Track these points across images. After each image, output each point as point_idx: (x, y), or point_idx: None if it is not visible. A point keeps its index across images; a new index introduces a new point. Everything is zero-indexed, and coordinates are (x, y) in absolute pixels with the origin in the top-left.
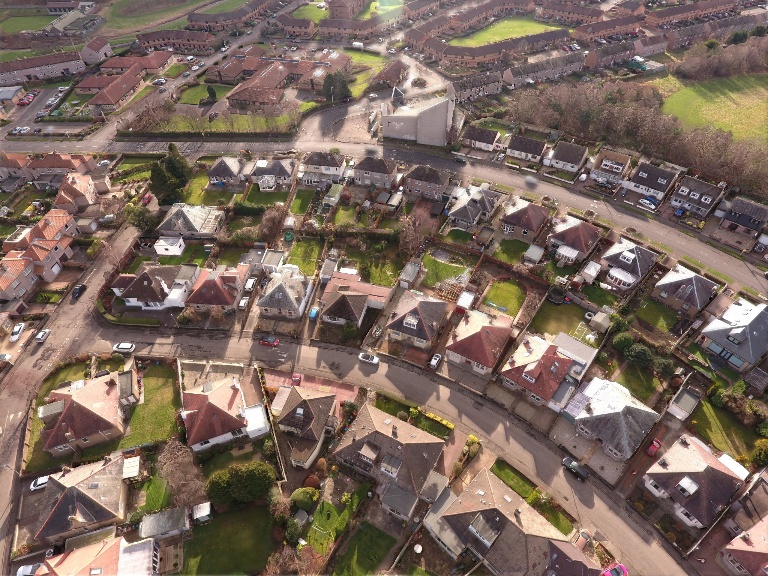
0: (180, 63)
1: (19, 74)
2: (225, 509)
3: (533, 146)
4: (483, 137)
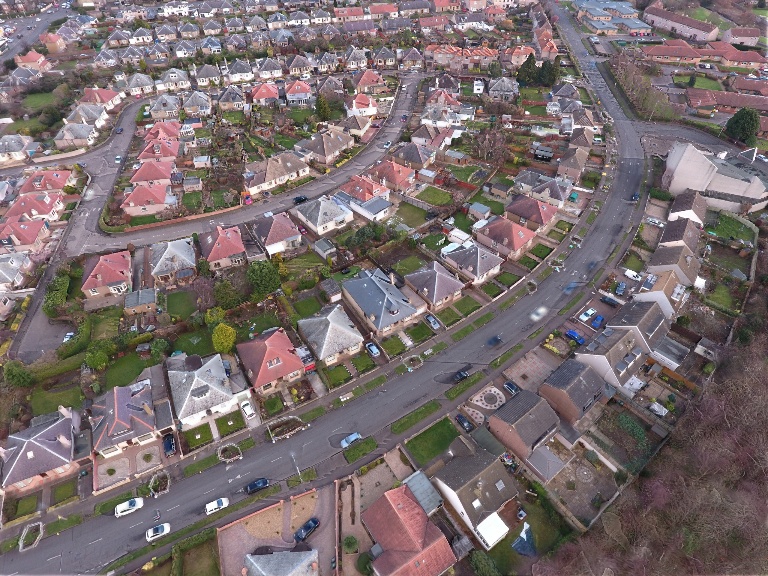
0: (756, 70)
1: (670, 24)
2: None
3: (674, 234)
4: (681, 205)
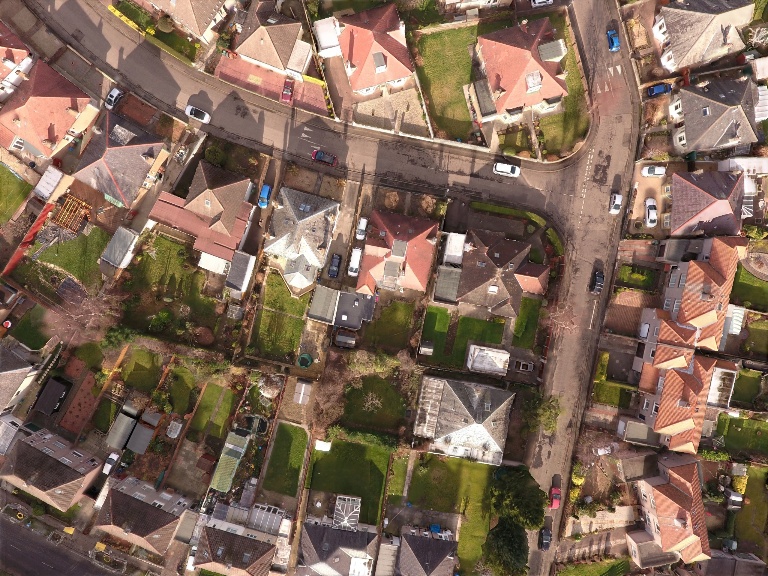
0: None
1: None
2: None
3: None
4: None
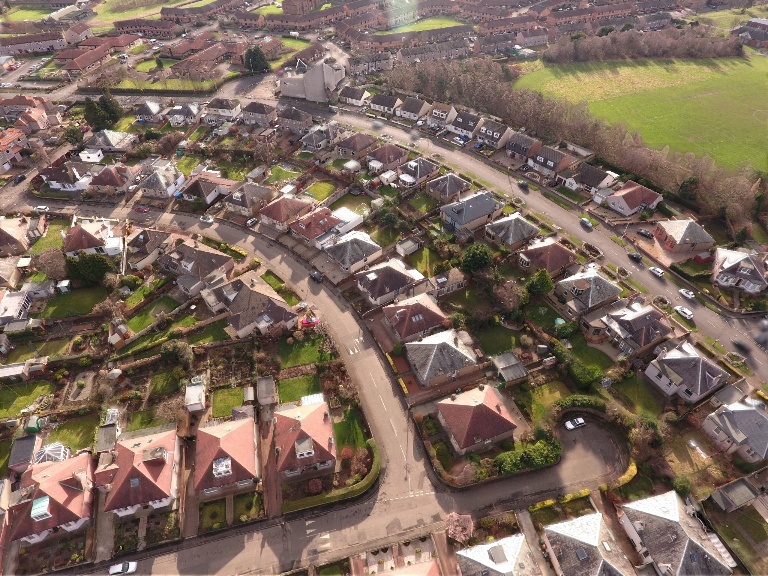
0: (144, 44)
1: (13, 48)
2: (79, 285)
3: (388, 101)
4: (354, 95)
